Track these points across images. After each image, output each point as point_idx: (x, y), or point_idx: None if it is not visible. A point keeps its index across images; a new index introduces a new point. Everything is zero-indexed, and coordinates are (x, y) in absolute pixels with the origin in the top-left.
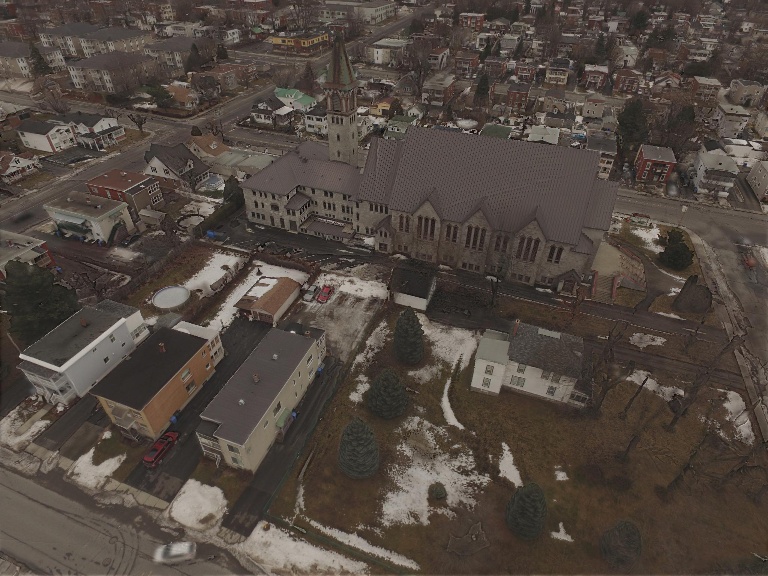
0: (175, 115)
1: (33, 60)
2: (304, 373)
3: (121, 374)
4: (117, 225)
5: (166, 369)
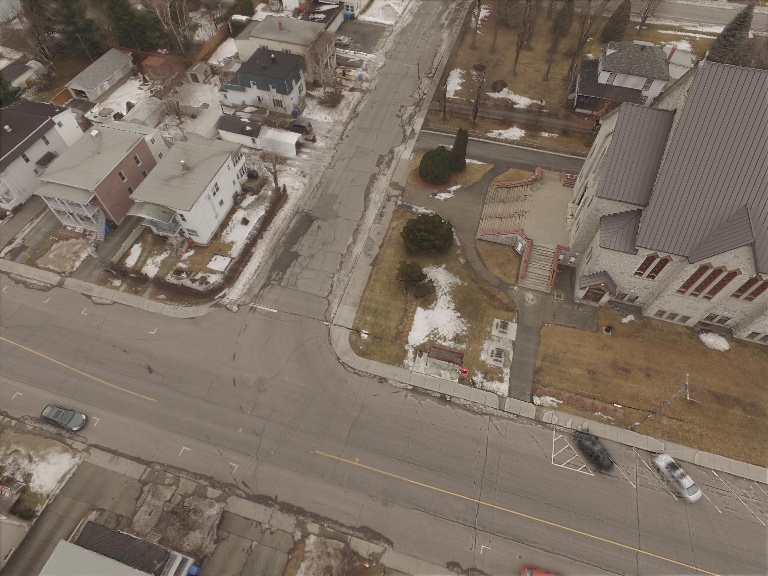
0: None
1: None
2: None
3: None
4: None
5: None
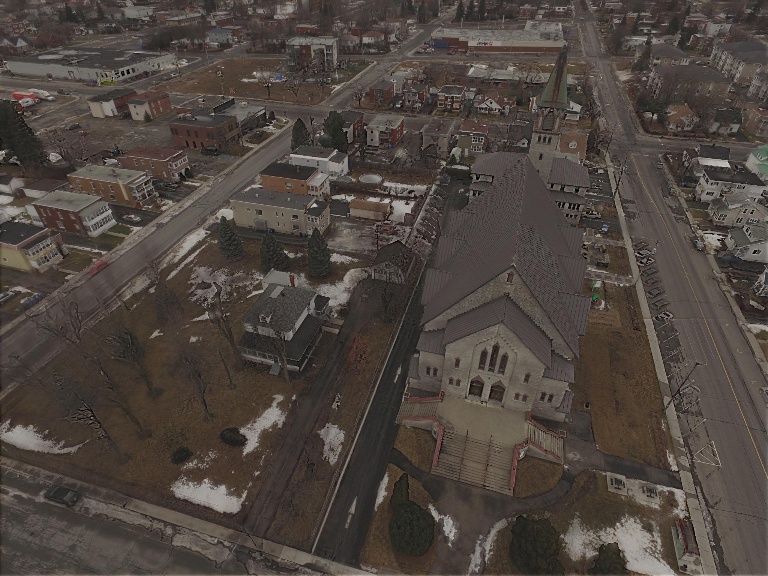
0: (645, 128)
1: (640, 58)
2: (288, 219)
3: (283, 166)
4: (433, 144)
5: (285, 175)
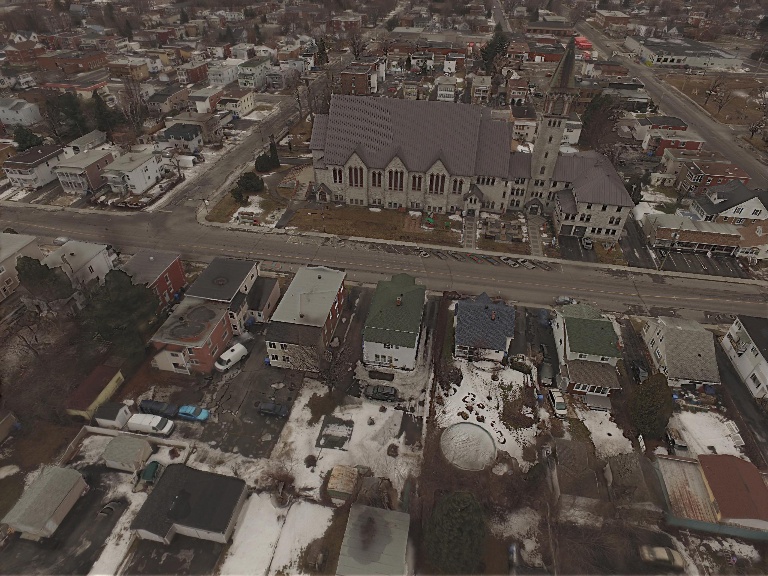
0: None
1: None
2: None
3: (531, 110)
4: None
5: (517, 112)
